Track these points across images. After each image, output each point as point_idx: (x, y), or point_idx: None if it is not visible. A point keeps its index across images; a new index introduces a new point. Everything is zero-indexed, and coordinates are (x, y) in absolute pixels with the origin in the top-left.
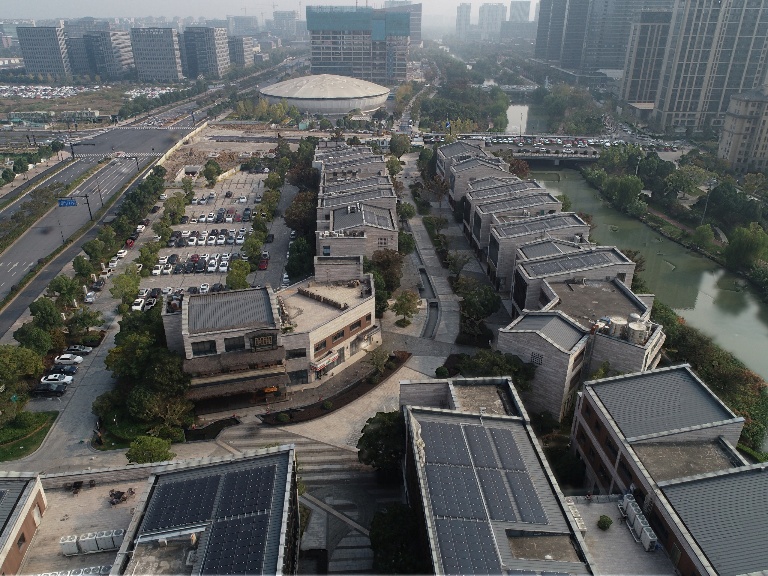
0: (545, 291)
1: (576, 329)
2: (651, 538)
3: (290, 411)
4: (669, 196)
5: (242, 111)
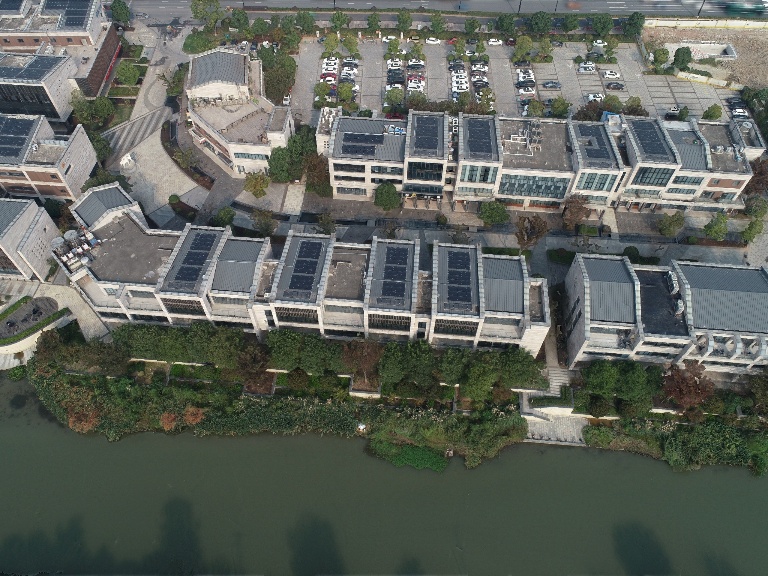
0: None
1: None
2: None
3: None
4: None
5: None
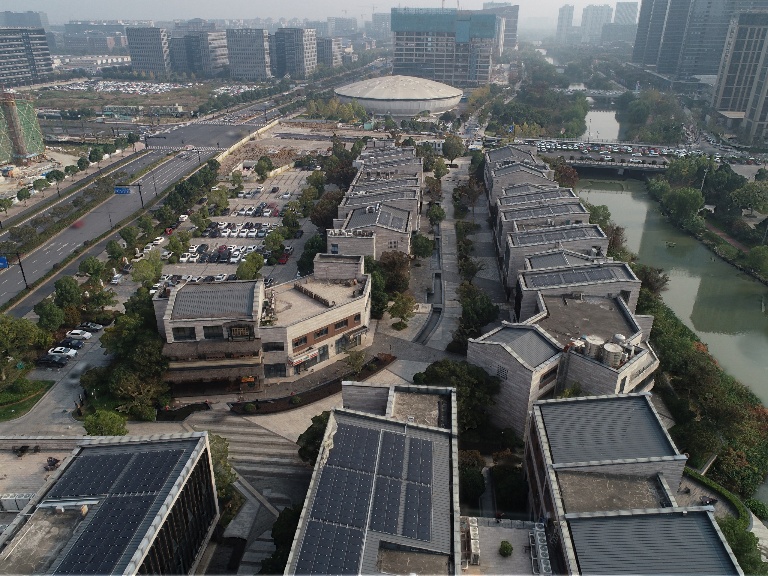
0: (538, 304)
1: (551, 345)
2: (545, 571)
3: (257, 402)
4: (732, 213)
5: (313, 110)
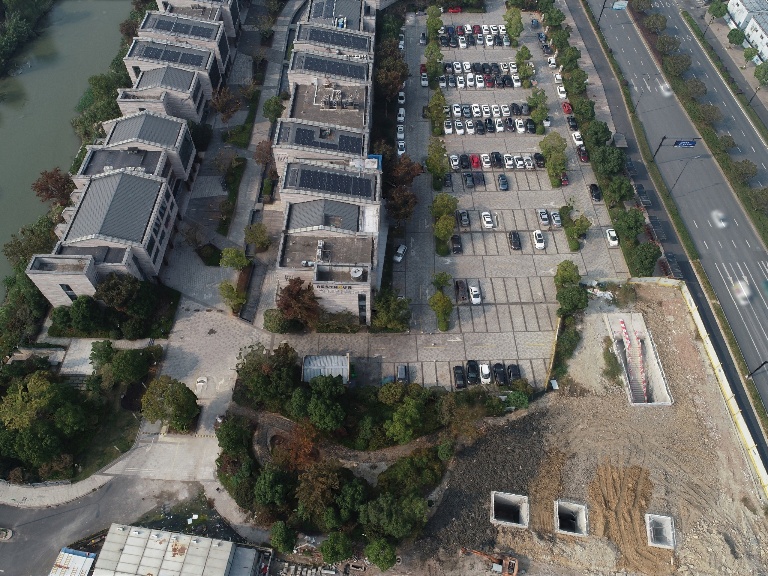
0: None
1: None
2: None
3: None
4: None
5: None
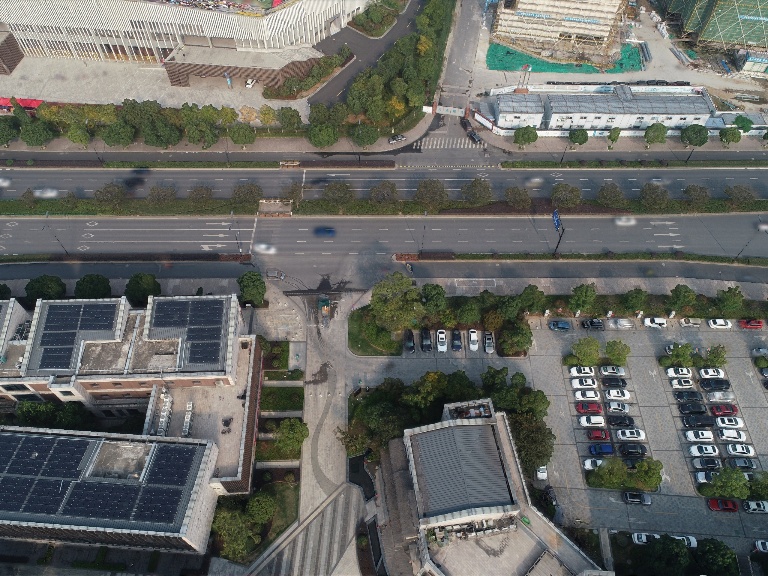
0: None
1: None
2: None
3: None
4: None
5: None
